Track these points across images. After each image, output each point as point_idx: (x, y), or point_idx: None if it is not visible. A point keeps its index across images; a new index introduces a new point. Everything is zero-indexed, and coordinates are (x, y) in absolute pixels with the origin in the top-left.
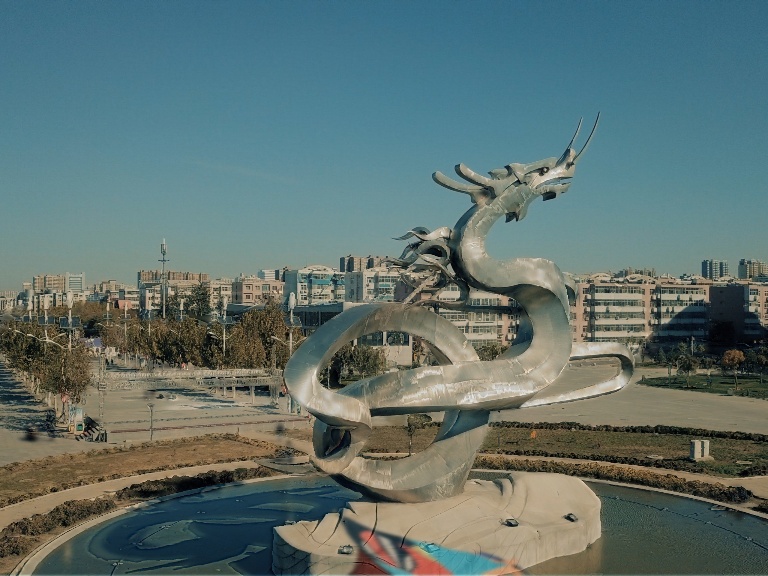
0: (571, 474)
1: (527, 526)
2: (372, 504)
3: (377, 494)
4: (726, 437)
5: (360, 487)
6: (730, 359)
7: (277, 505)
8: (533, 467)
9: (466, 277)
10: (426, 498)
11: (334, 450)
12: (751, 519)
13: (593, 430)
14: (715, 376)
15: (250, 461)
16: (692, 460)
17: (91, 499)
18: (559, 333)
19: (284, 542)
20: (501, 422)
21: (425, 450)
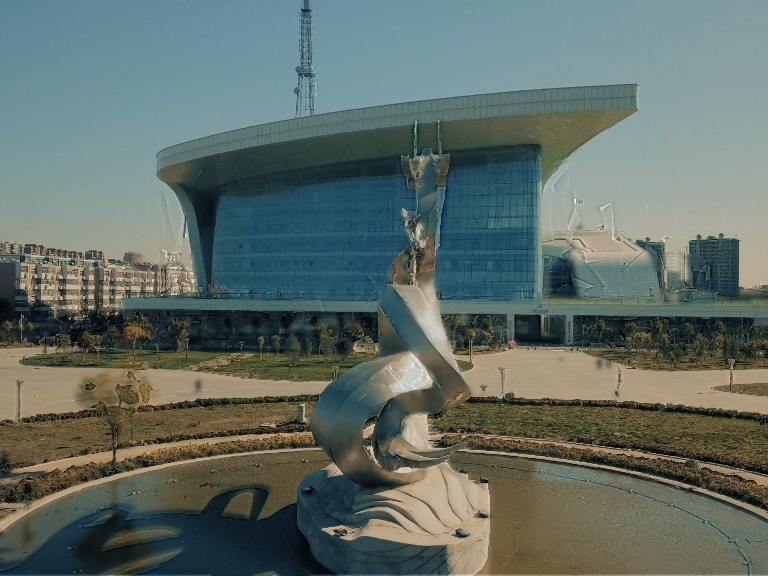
0: (269, 449)
1: None
2: (395, 491)
3: (394, 480)
4: (263, 402)
5: (373, 477)
6: (131, 335)
7: (123, 539)
8: (233, 448)
9: (422, 260)
10: (424, 474)
11: (380, 441)
12: (457, 454)
13: (143, 411)
14: (80, 353)
15: None
16: (302, 422)
17: None
18: (435, 312)
19: (403, 545)
20: (36, 416)
21: (405, 429)
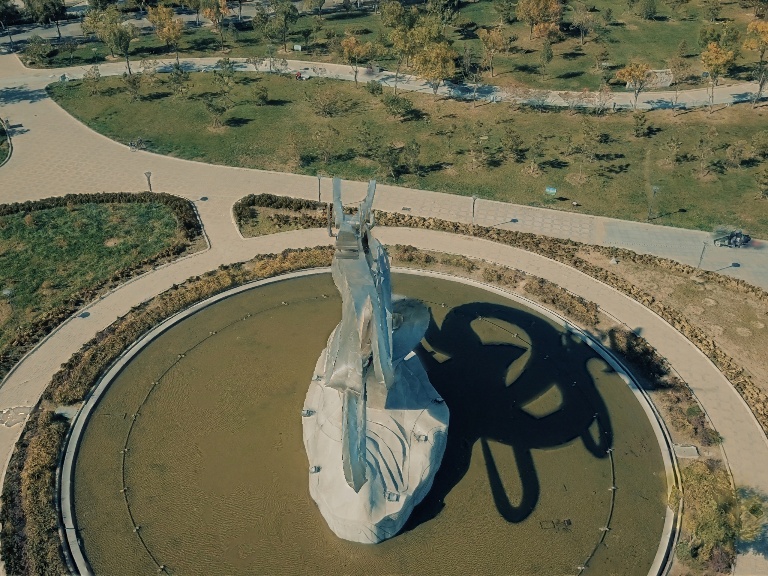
0: None
1: (309, 429)
2: None
3: None
4: None
5: None
6: None
7: (555, 401)
8: None
9: None
10: None
11: None
12: None
13: None
14: None
15: (764, 438)
16: None
17: (613, 317)
18: None
19: None
20: None
21: None
